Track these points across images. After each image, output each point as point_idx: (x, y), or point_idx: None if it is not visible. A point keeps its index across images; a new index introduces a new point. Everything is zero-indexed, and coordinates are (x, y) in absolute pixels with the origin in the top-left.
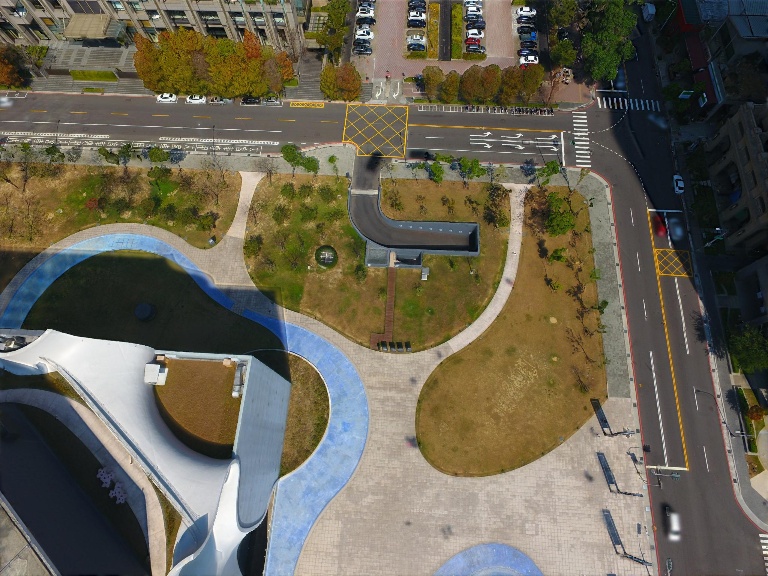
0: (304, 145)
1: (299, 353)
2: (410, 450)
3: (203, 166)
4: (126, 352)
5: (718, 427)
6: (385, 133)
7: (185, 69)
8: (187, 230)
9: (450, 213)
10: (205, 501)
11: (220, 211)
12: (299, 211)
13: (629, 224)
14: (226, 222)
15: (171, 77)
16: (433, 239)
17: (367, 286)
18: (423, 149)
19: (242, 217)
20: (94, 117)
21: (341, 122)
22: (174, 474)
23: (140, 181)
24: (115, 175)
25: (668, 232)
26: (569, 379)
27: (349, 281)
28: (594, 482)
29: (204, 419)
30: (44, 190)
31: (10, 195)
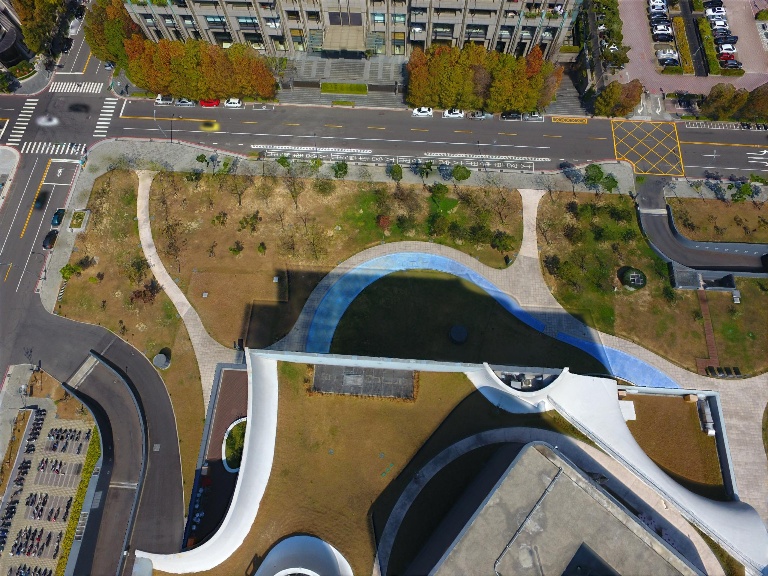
0: (577, 162)
1: (626, 378)
2: (767, 480)
3: (478, 183)
4: (609, 389)
5: None
6: (658, 150)
7: (467, 84)
8: (478, 249)
9: (747, 234)
10: (760, 549)
11: (507, 230)
12: (589, 230)
13: None
14: (516, 241)
15: (446, 92)
16: (727, 260)
17: (680, 309)
18: (701, 167)
19: (531, 236)
20: (351, 131)
21: (609, 138)
22: (712, 520)
23: (415, 198)
24: (388, 191)
25: None
26: None
27: (660, 304)
28: None
29: (683, 458)
30: (318, 206)
31: (283, 211)
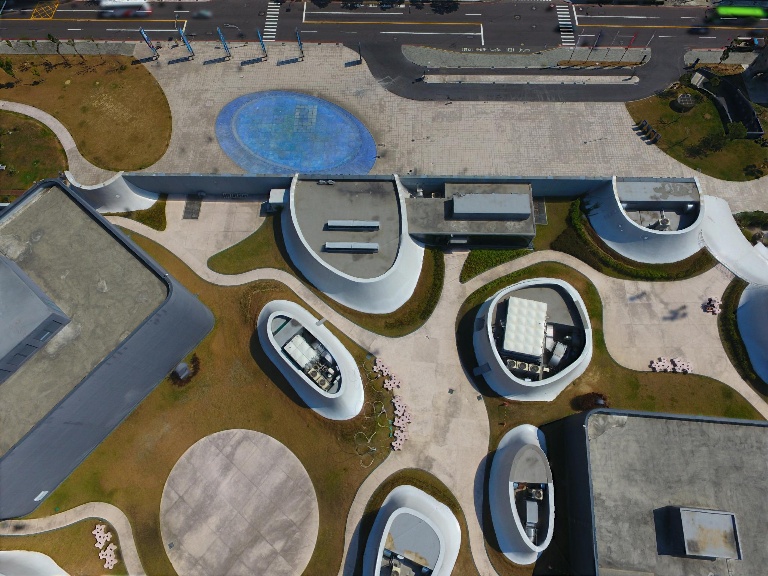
0: None
1: None
2: None
3: None
4: None
5: (164, 4)
6: None
7: None
8: None
9: None
10: None
11: None
12: None
13: (5, 31)
14: None
15: None
16: None
17: None
18: None
19: None
20: None
21: None
22: None
23: None
24: None
25: (20, 10)
26: (114, 76)
27: None
28: (186, 68)
29: None
30: None
31: None
